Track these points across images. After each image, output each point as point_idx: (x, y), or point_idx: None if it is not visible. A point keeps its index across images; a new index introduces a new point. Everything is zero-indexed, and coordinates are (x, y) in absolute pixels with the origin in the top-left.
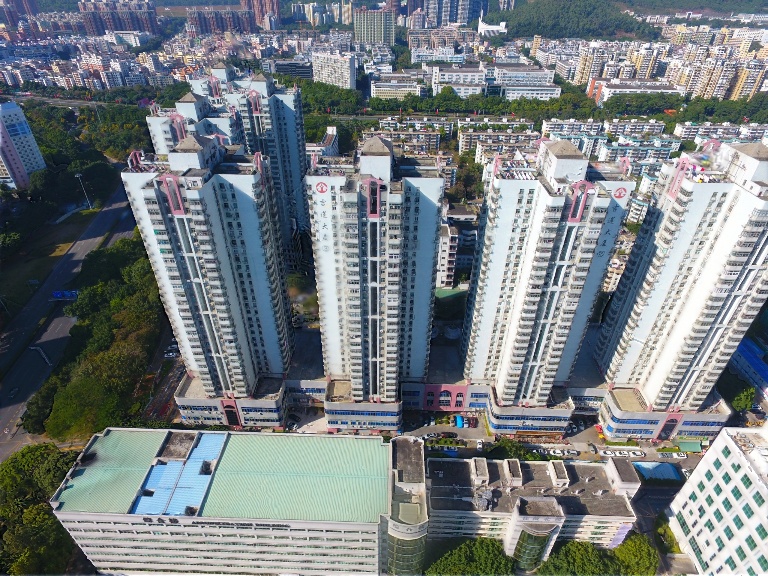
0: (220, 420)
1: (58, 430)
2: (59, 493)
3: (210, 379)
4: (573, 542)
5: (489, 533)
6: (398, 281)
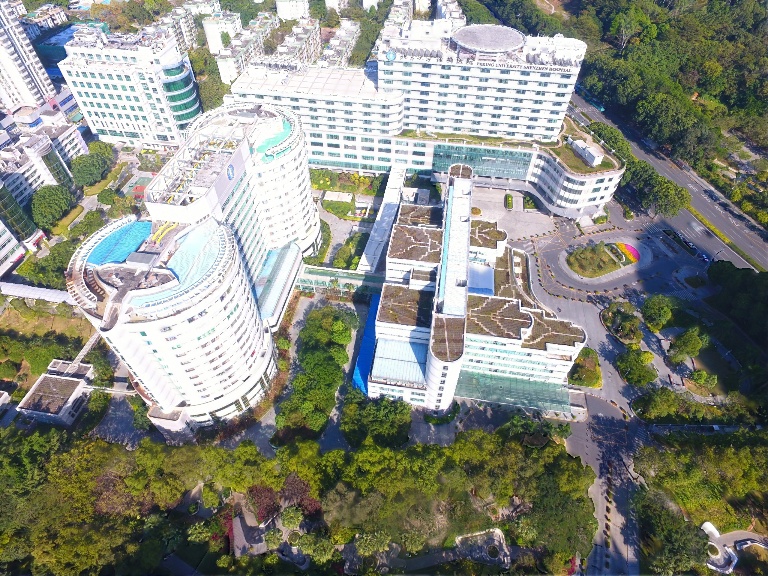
0: None
1: None
2: None
3: None
4: (72, 160)
5: (37, 185)
6: None
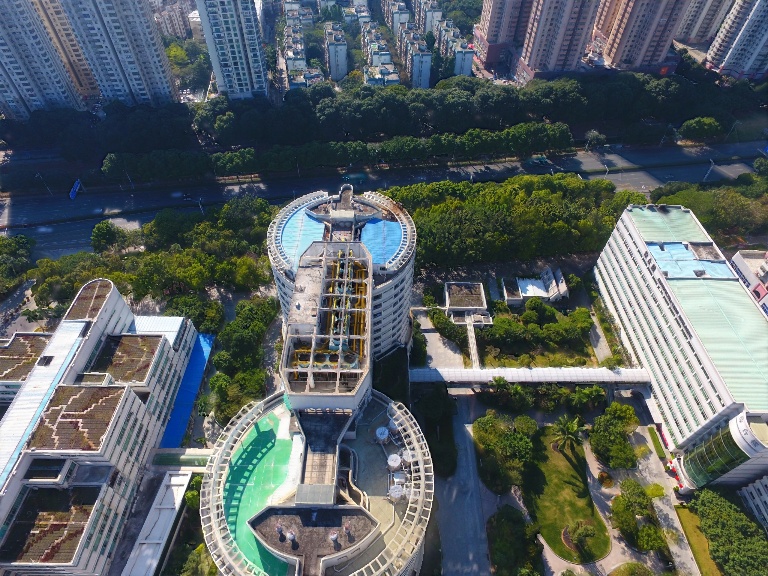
0: None
1: None
2: (636, 207)
3: None
4: None
5: None
6: None
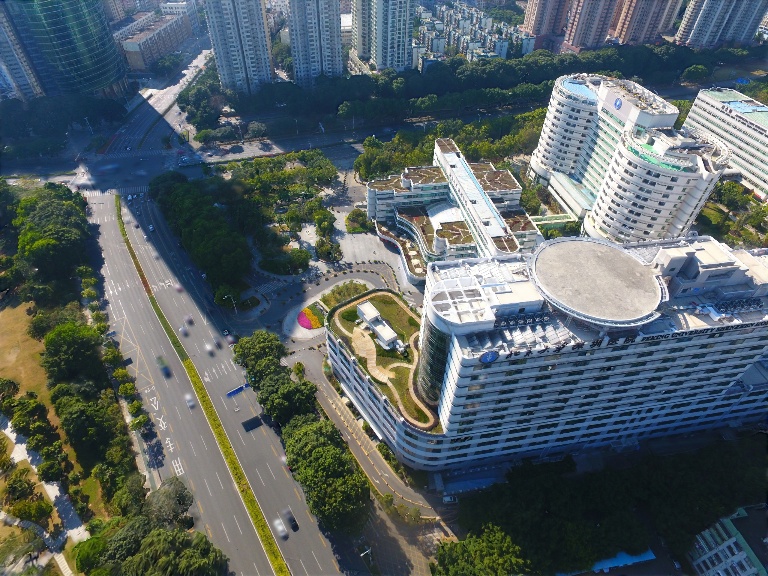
0: None
1: None
2: (704, 90)
3: None
4: None
5: None
6: None
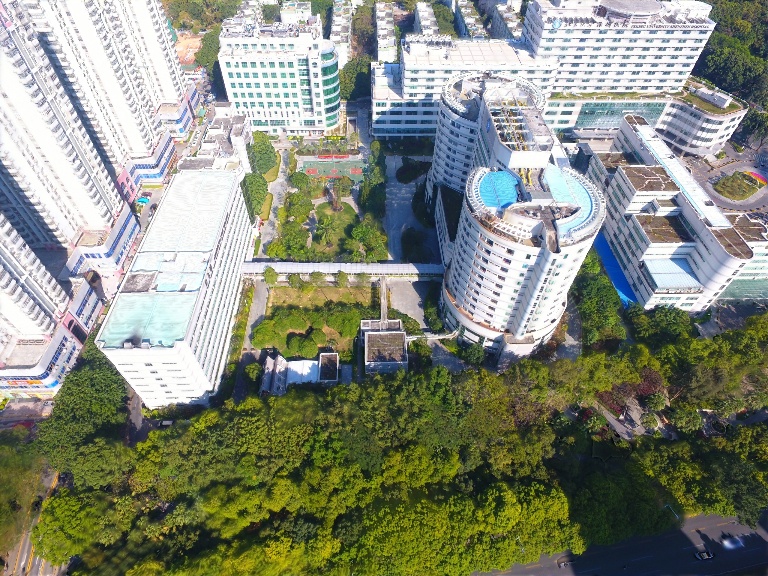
0: (75, 349)
1: (13, 524)
2: None
3: (40, 310)
4: None
5: None
6: (59, 82)
